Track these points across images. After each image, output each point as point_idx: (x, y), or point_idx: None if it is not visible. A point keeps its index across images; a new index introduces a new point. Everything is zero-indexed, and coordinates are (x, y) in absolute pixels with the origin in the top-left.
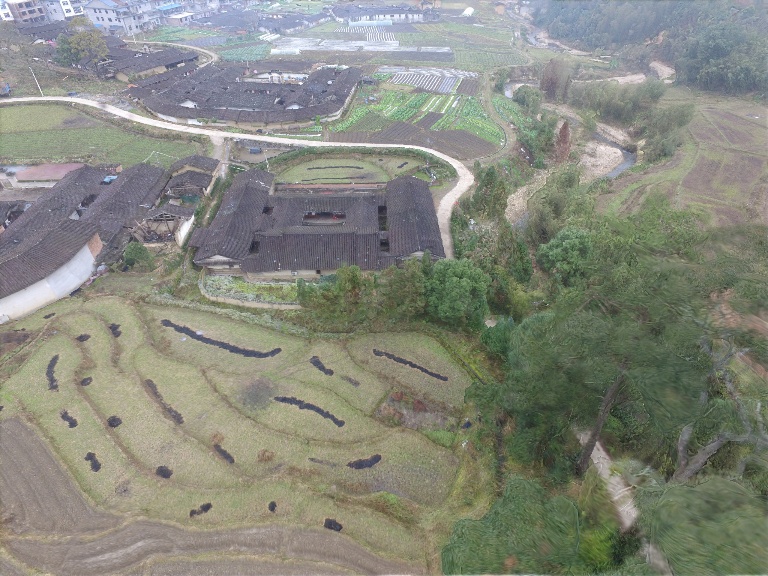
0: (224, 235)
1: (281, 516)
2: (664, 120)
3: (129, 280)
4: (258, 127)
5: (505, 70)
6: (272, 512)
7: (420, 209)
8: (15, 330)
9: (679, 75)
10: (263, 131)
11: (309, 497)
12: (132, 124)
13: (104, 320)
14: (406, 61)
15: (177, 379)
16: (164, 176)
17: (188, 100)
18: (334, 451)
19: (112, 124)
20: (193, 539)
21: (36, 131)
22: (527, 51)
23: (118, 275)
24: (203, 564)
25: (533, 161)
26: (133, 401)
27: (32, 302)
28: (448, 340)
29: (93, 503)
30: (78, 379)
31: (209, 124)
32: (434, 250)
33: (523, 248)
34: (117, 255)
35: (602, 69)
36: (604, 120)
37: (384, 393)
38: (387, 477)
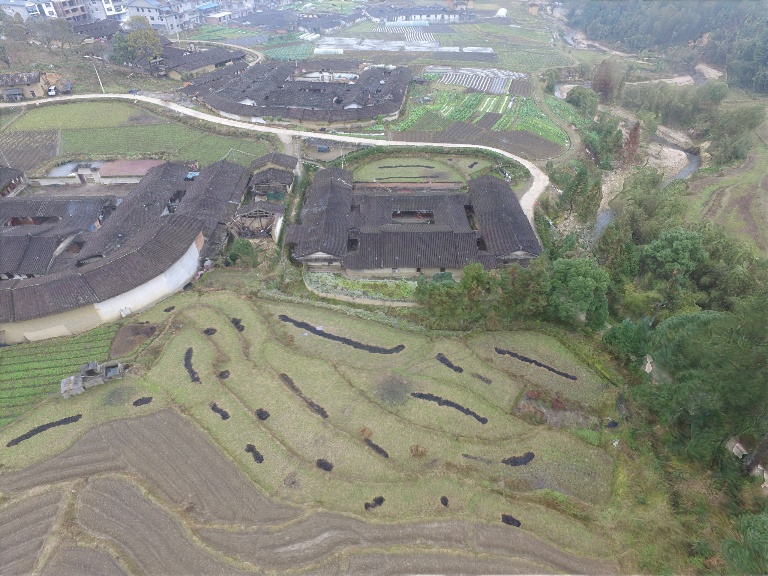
0: (322, 232)
1: (456, 511)
2: (732, 122)
3: (235, 275)
4: (321, 126)
5: None
6: (446, 507)
7: (509, 209)
8: (140, 323)
9: (731, 77)
10: (326, 130)
11: (480, 493)
12: (198, 121)
13: (225, 314)
14: (451, 61)
15: (311, 374)
16: (245, 173)
17: (247, 98)
18: (485, 448)
19: (178, 121)
20: (379, 531)
21: (104, 128)
22: (570, 52)
23: (223, 270)
24: (397, 556)
25: (598, 162)
26: (275, 394)
27: (150, 295)
28: (567, 340)
29: (268, 494)
30: (217, 372)
31: (273, 122)
32: (534, 250)
33: (632, 249)
34: (218, 250)
35: (648, 71)
36: (661, 122)
37: (519, 391)
38: (545, 475)
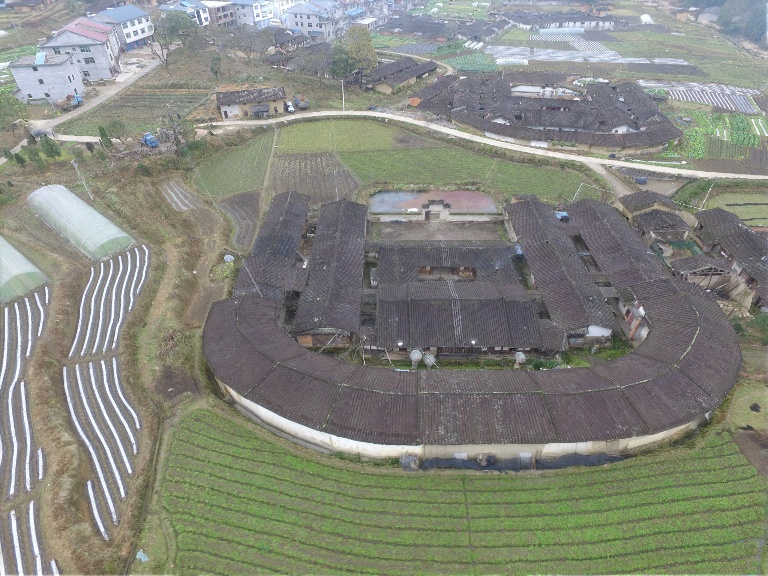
0: None
1: None
2: None
3: (760, 356)
4: (612, 152)
5: None
6: None
7: None
8: (741, 427)
9: None
10: (616, 156)
11: None
12: (480, 145)
13: None
14: (657, 75)
15: None
16: (618, 214)
17: (500, 118)
18: None
19: (453, 144)
20: None
21: (380, 151)
22: None
23: None
24: None
25: None
26: None
27: None
28: None
29: None
30: None
31: (555, 147)
32: None
33: None
34: None
35: None
36: None
37: None
38: None
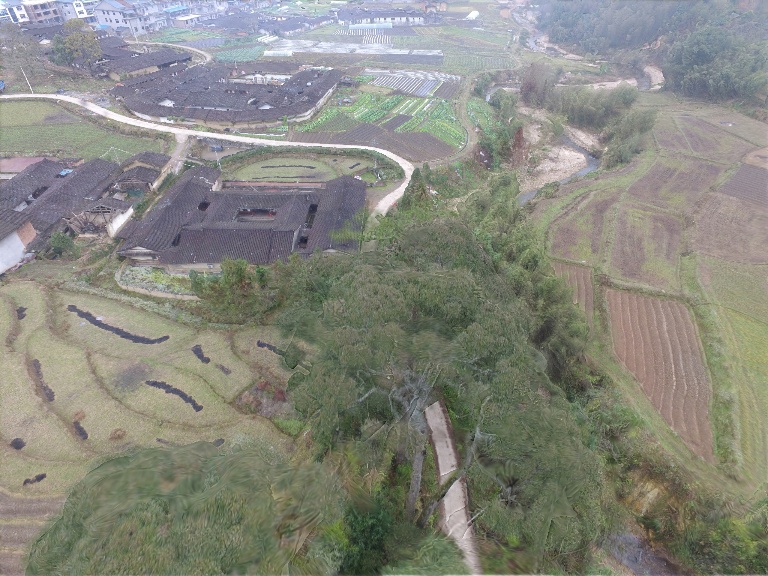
0: (150, 228)
1: None
2: (627, 126)
3: (53, 267)
4: (226, 126)
5: (490, 74)
6: None
7: (347, 208)
8: None
9: (667, 81)
10: (230, 130)
11: None
12: (106, 121)
13: (14, 303)
14: (394, 64)
15: (62, 360)
16: (117, 171)
17: (167, 99)
18: (182, 433)
19: (89, 121)
20: (14, 504)
21: (17, 126)
22: (519, 55)
23: (44, 262)
24: (13, 527)
25: None
26: (13, 378)
27: None
28: None
29: None
30: None
31: (180, 122)
32: (347, 248)
33: None
34: (48, 244)
35: (593, 74)
36: (578, 125)
37: (250, 382)
38: None
